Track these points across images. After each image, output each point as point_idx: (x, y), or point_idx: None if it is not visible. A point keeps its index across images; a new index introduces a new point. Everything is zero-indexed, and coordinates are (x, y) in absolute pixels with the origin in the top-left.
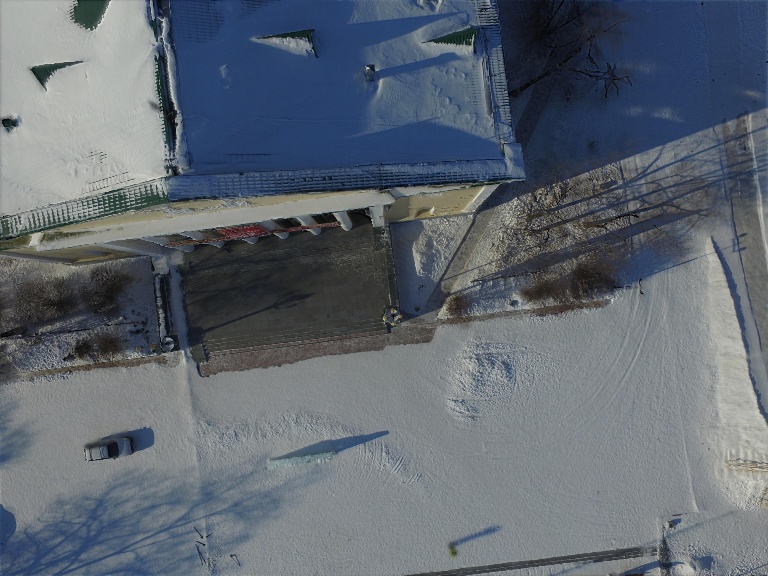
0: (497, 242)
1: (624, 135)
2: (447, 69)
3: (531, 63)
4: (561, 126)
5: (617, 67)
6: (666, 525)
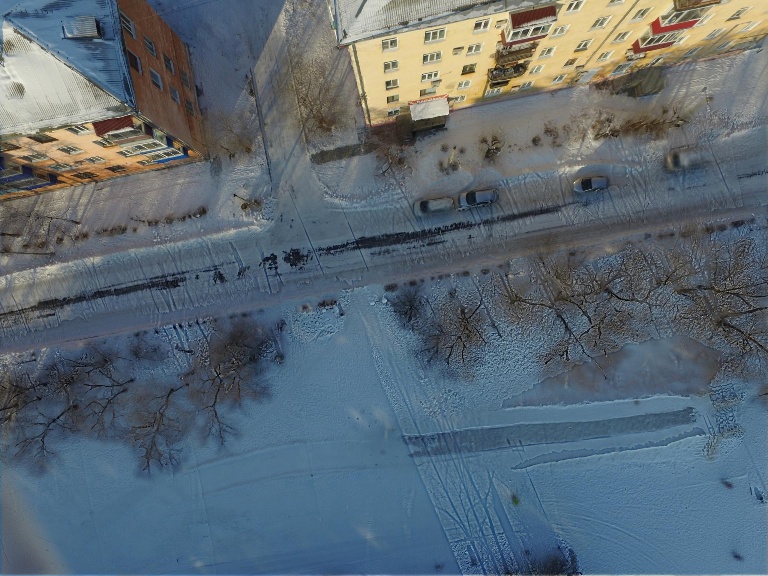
0: None
1: (427, 539)
2: None
3: None
4: None
5: (370, 546)
6: (760, 501)
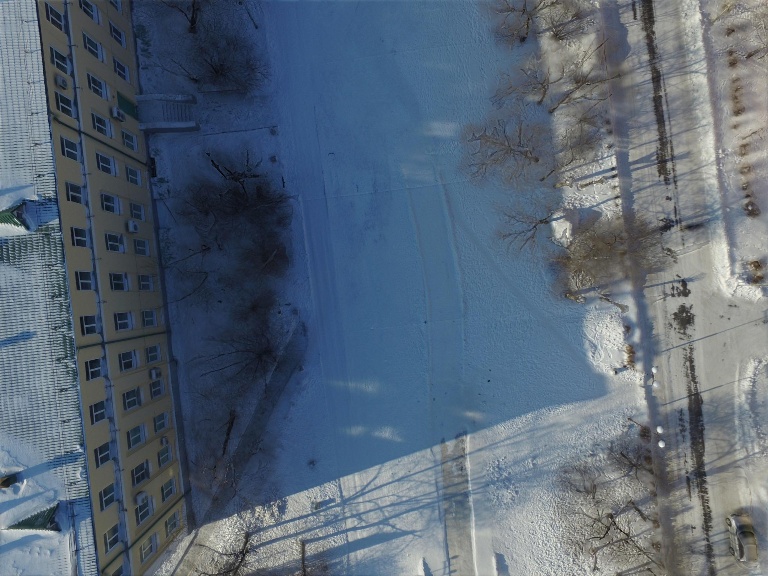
0: (217, 557)
1: (344, 452)
2: (30, 549)
3: (253, 381)
4: (281, 445)
5: (339, 384)
6: None
